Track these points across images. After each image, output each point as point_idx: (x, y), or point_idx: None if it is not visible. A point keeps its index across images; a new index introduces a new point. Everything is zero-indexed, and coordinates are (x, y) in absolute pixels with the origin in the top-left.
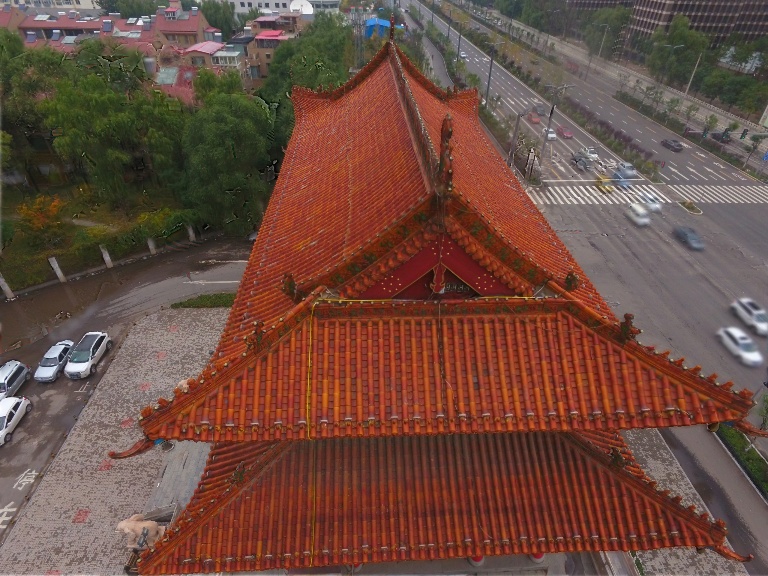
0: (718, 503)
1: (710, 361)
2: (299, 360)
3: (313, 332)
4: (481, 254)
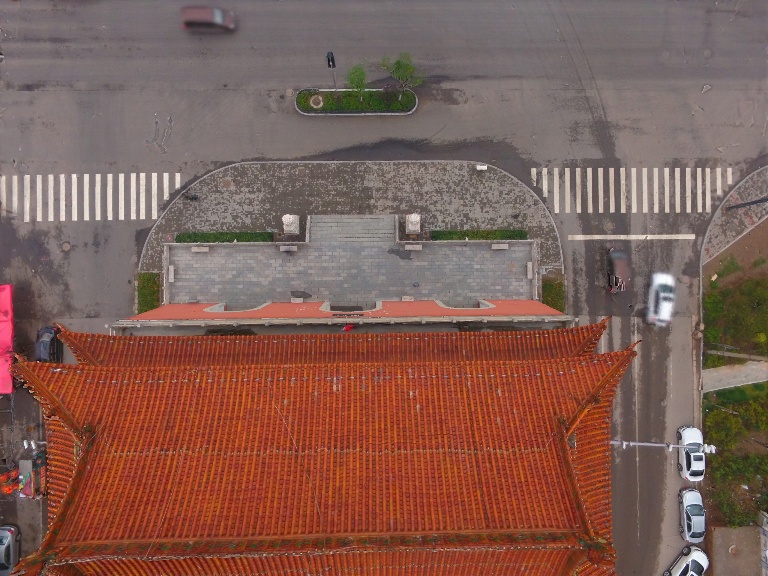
0: (400, 149)
1: (258, 64)
2: (588, 572)
3: (578, 570)
4: (586, 497)
